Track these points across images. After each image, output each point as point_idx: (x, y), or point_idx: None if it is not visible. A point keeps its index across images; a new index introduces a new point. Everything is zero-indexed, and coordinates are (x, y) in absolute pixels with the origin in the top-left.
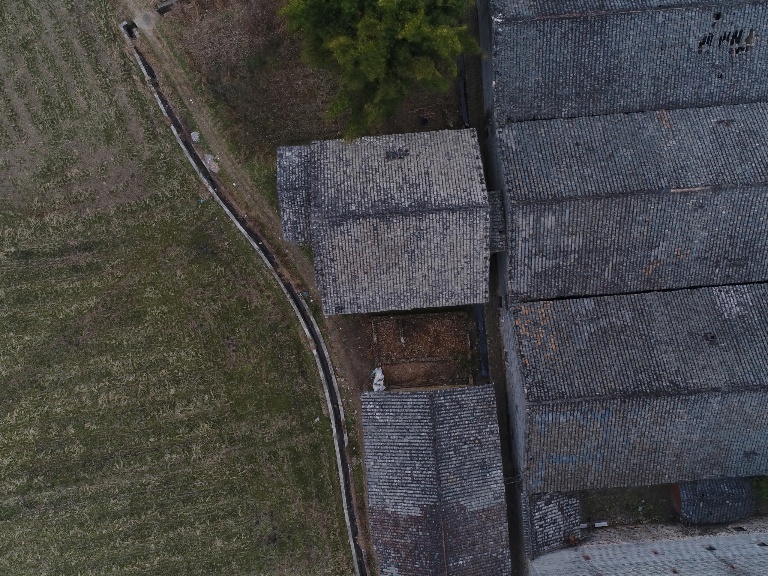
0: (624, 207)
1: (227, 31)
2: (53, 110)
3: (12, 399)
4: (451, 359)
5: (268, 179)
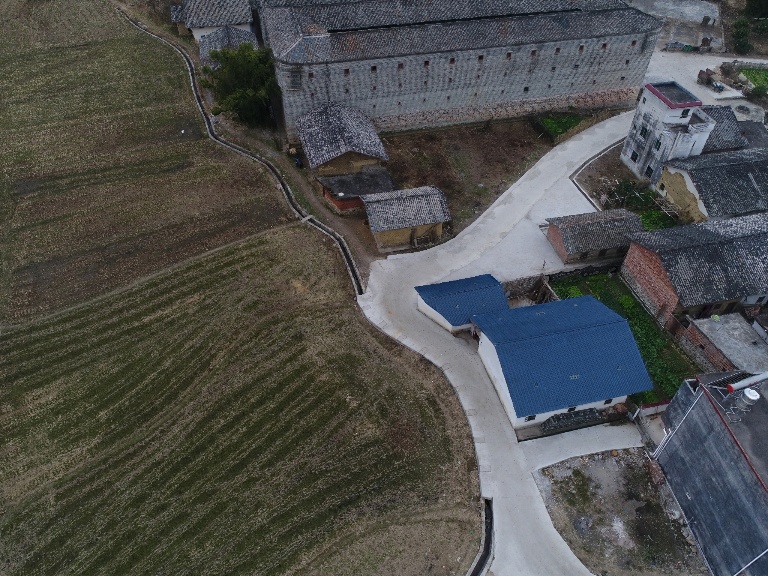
0: None
1: (157, 8)
2: None
3: None
4: None
5: None
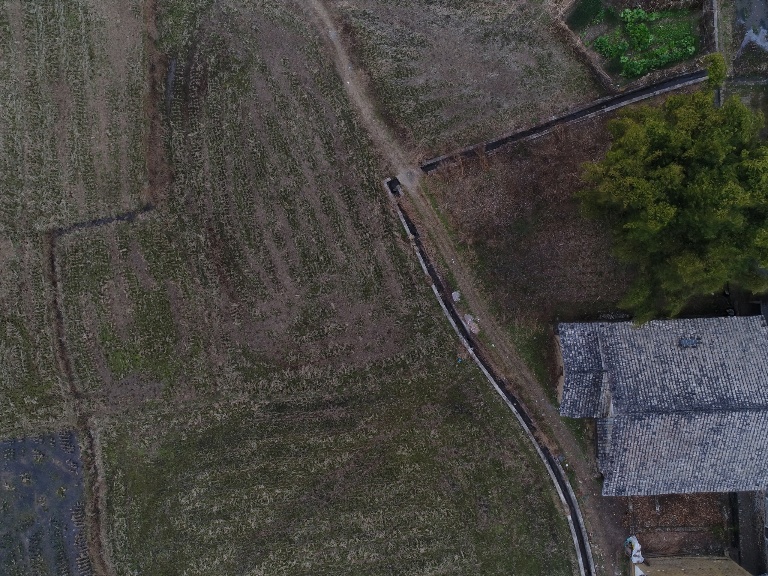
0: None
1: (490, 190)
2: (311, 263)
3: (260, 551)
4: (707, 530)
5: (528, 342)
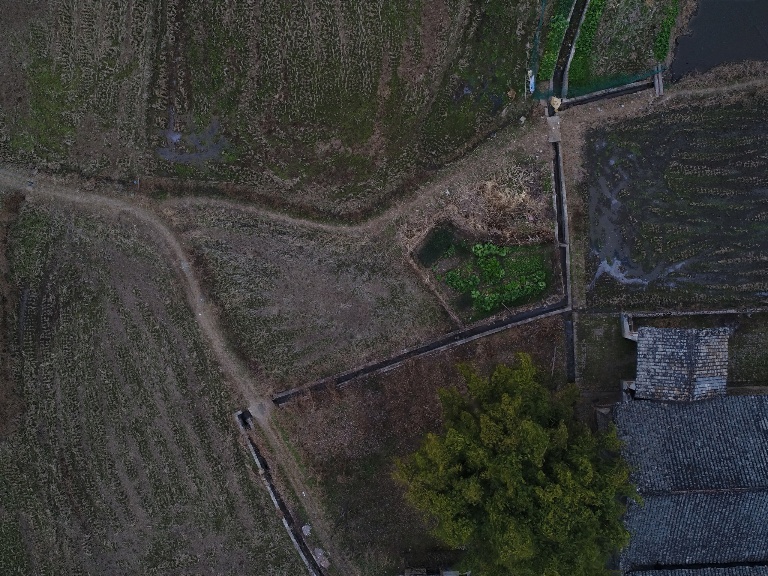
0: None
1: (342, 422)
2: (163, 493)
3: None
4: None
5: None
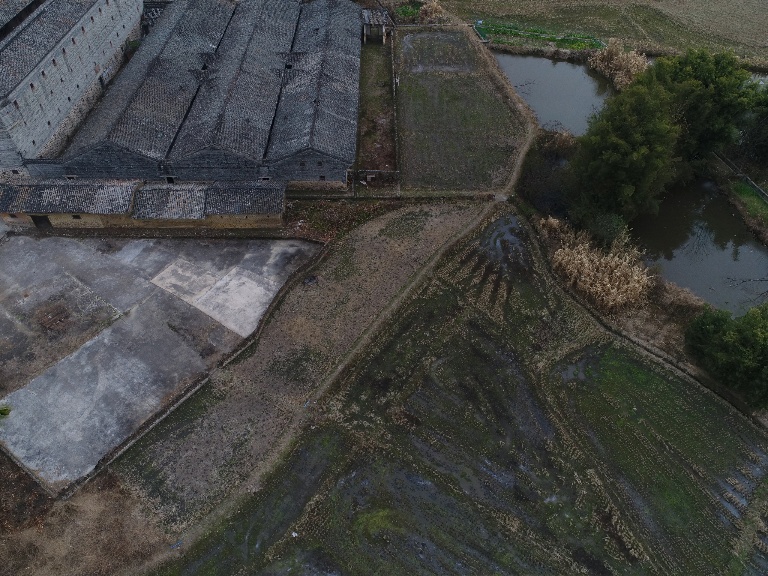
0: (259, 6)
1: None
2: None
3: None
4: None
5: None
